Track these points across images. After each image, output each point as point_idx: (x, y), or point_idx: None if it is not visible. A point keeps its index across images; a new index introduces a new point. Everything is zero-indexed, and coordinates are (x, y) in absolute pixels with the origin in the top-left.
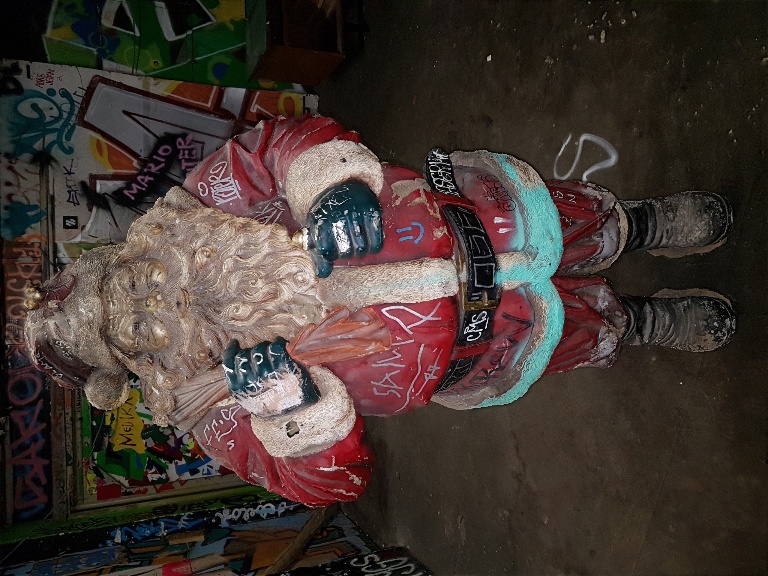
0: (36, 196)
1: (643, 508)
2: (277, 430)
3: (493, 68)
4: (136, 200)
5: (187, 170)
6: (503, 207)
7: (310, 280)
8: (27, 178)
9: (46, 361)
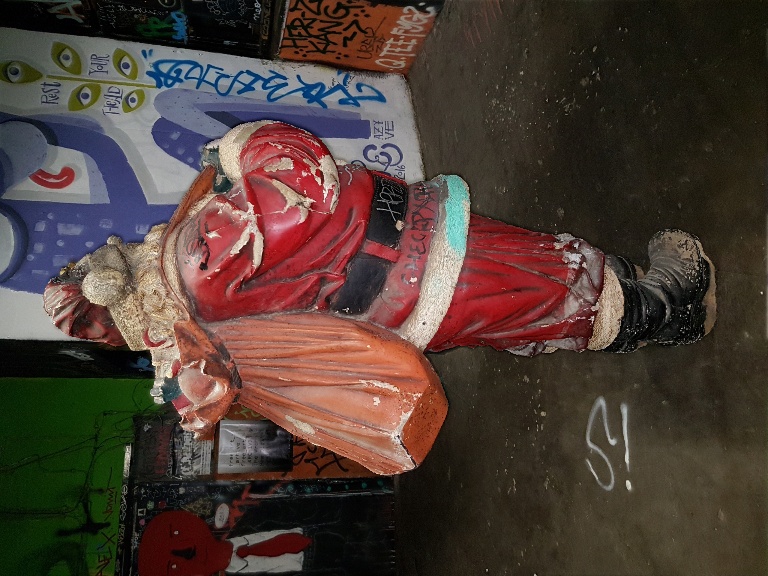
0: None
1: None
2: None
3: (541, 573)
4: None
5: None
6: None
7: None
8: None
9: None
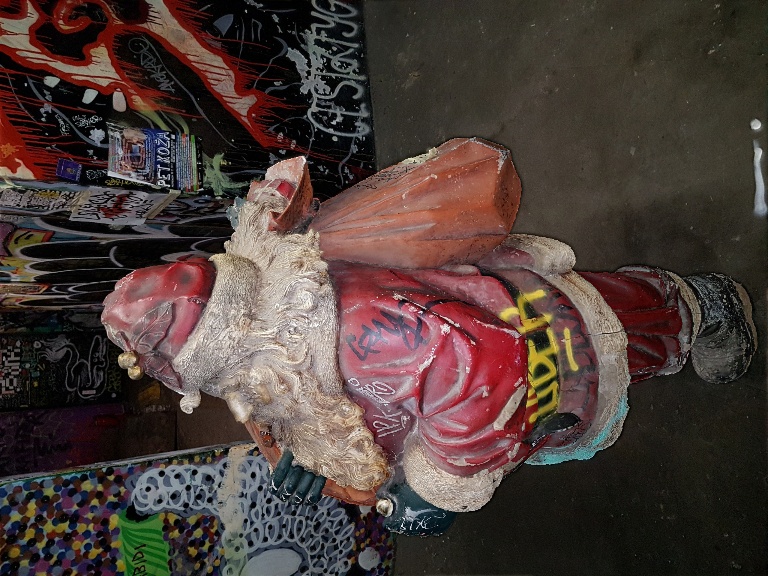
0: None
1: None
2: None
3: None
4: None
5: None
6: None
7: None
8: None
9: None
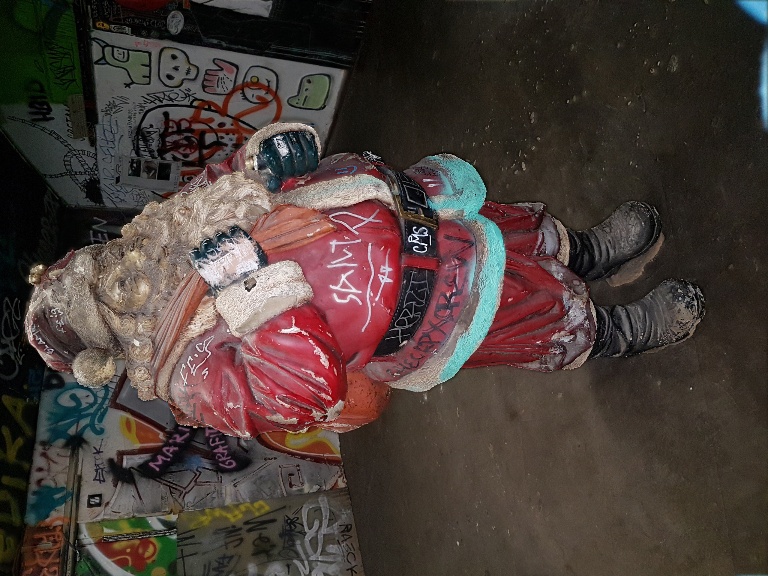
0: (64, 478)
1: (720, 557)
2: (236, 288)
3: None
4: (161, 471)
5: (211, 436)
6: (429, 174)
7: (264, 201)
8: (57, 462)
9: (40, 336)
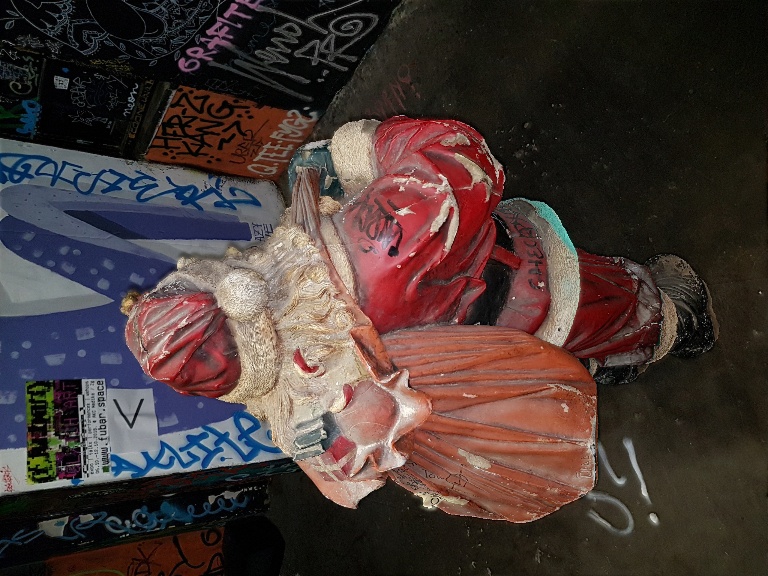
0: None
1: None
2: None
3: None
4: None
5: None
6: None
7: None
8: None
9: None
